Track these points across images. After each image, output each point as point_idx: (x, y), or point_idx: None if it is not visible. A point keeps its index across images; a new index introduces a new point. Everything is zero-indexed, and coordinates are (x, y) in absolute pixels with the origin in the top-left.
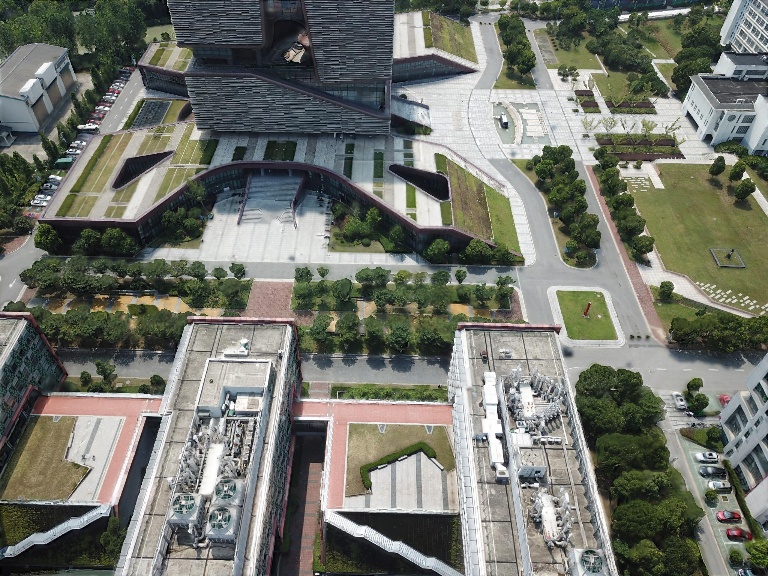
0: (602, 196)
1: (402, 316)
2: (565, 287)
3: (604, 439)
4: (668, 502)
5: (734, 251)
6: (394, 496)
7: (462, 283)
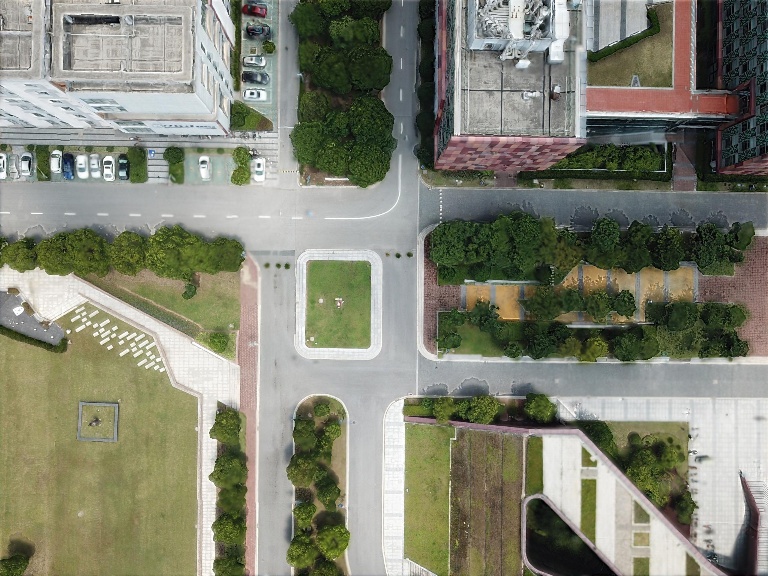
0: (247, 569)
1: (601, 266)
2: (355, 357)
3: (383, 79)
4: (335, 7)
5: (82, 437)
6: (623, 2)
7: (499, 361)
